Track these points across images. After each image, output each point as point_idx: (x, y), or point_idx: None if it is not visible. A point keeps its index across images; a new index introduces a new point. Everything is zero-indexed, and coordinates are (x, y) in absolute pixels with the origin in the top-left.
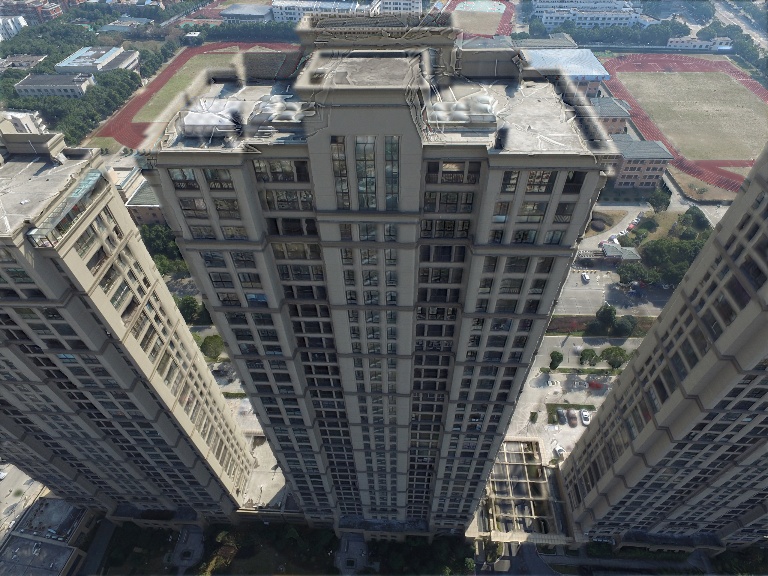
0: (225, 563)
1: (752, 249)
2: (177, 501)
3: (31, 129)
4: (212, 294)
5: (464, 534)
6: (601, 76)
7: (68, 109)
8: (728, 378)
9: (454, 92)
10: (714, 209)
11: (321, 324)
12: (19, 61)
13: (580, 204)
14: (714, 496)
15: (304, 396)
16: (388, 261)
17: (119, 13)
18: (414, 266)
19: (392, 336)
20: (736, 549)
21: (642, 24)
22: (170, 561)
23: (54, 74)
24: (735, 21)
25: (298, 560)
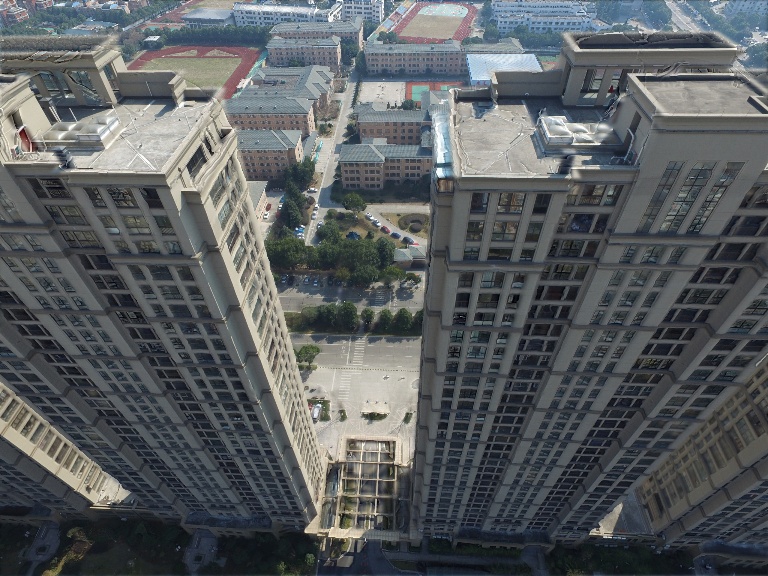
0: (75, 558)
1: (429, 257)
2: None
3: None
4: None
5: (304, 530)
6: None
7: None
8: (434, 379)
9: (74, 113)
10: None
11: (41, 327)
12: None
13: (172, 218)
14: (514, 494)
15: (65, 395)
16: (52, 269)
17: (84, 17)
18: (78, 273)
19: (108, 339)
20: (571, 546)
21: (594, 29)
22: (25, 556)
23: None
24: (691, 26)
25: (148, 555)
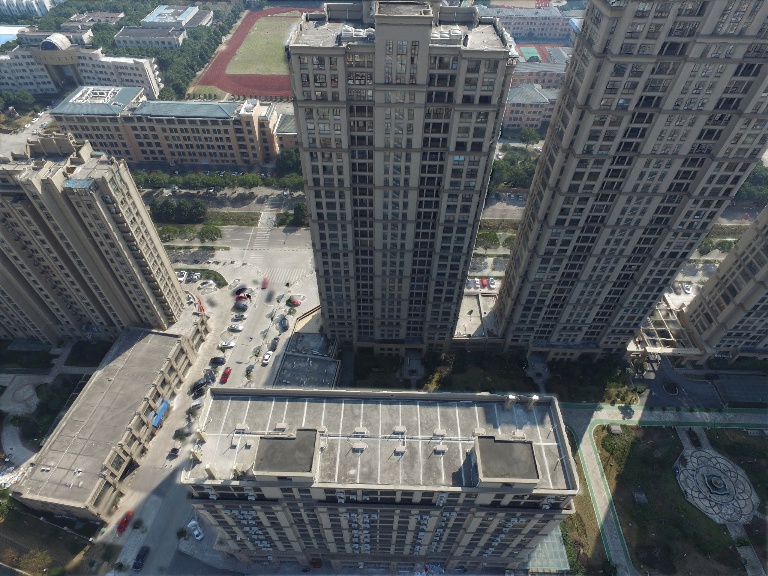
0: None
1: None
2: (410, 329)
3: (149, 74)
4: (599, 99)
5: (626, 349)
6: None
7: (170, 59)
8: None
9: None
10: None
11: (641, 130)
12: (98, 17)
13: None
14: None
15: None
16: (717, 74)
17: None
18: (730, 77)
19: (683, 138)
20: None
21: None
22: (402, 376)
23: (147, 28)
24: None
25: (500, 373)
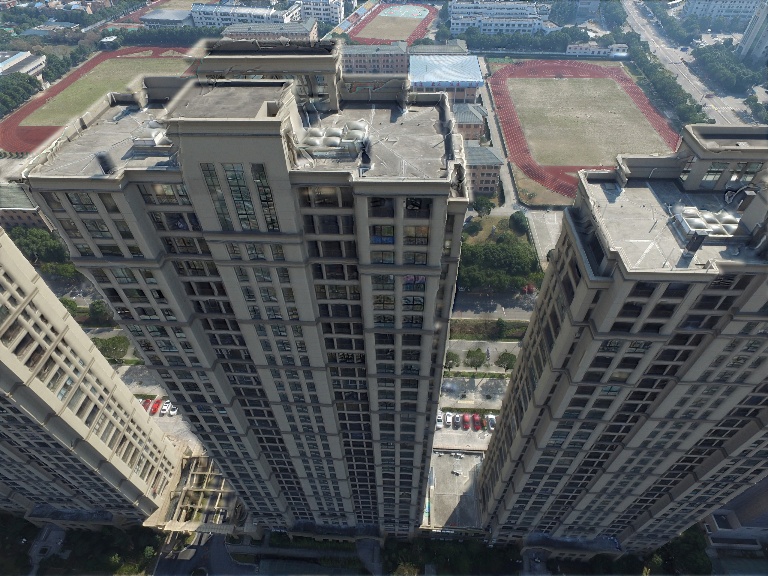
0: None
1: None
2: None
3: None
4: None
5: None
6: (475, 82)
7: None
8: None
9: None
10: (542, 214)
11: None
12: None
13: None
14: (318, 487)
15: None
16: None
17: (46, 17)
18: None
19: None
20: (406, 540)
21: (545, 31)
22: None
23: None
24: (646, 28)
25: None
